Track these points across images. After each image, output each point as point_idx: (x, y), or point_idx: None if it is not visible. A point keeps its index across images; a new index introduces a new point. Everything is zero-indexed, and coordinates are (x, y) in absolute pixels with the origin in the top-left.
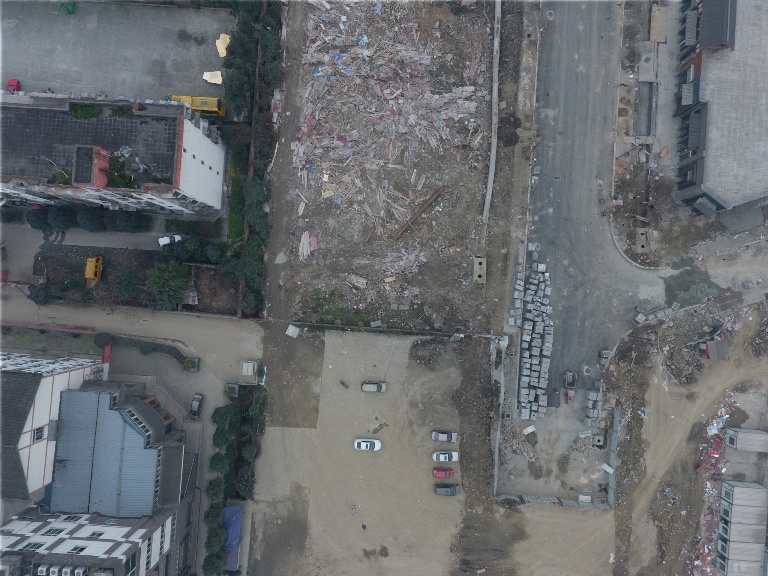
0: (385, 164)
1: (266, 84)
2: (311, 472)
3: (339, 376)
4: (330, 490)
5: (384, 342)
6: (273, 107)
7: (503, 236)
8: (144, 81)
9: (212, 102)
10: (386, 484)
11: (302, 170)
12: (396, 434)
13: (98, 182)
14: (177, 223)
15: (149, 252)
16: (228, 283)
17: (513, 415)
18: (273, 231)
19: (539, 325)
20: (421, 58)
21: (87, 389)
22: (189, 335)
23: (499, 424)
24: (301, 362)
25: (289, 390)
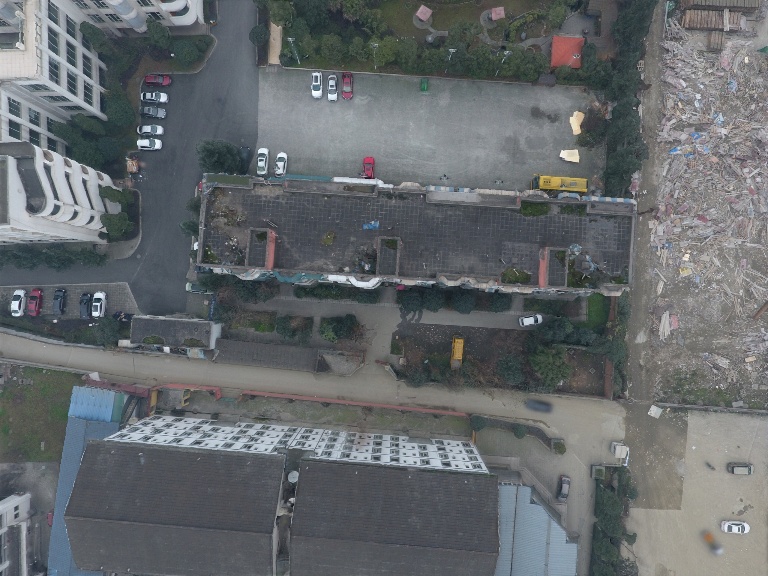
0: (743, 243)
1: None
2: (676, 554)
3: (703, 457)
4: (695, 573)
5: (747, 423)
6: (631, 186)
7: None
8: (498, 158)
9: (582, 183)
10: (752, 567)
11: (661, 249)
12: (761, 516)
13: None
14: (537, 302)
15: (508, 331)
16: (587, 362)
17: None
18: (632, 310)
19: None
20: None
21: None
22: (550, 415)
23: None
24: (664, 443)
25: (652, 471)
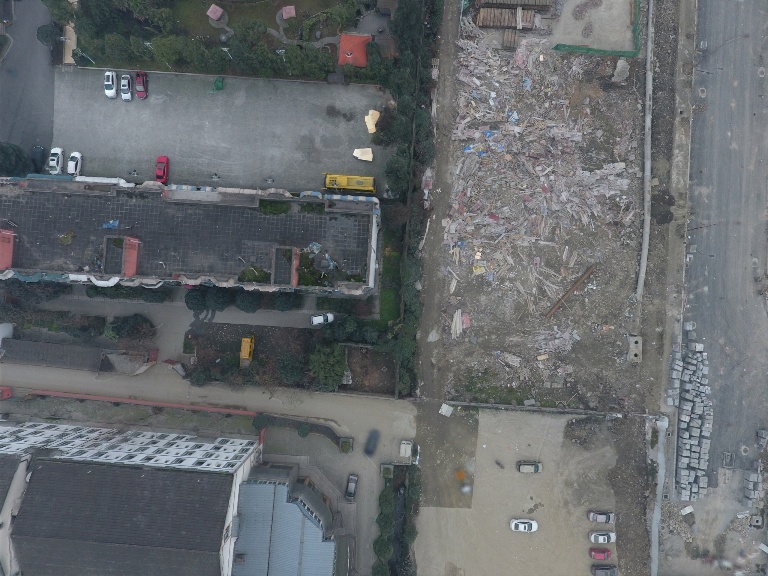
0: (536, 241)
1: (420, 162)
2: (466, 553)
3: (493, 455)
4: (485, 571)
5: (538, 421)
6: (424, 184)
7: (658, 314)
8: (293, 157)
9: (368, 181)
10: (542, 565)
11: (454, 247)
12: (551, 514)
13: (294, 282)
14: (329, 301)
15: (300, 330)
16: (380, 361)
17: (671, 496)
18: (425, 309)
19: (698, 406)
20: (573, 135)
21: (256, 478)
22: (342, 414)
23: (657, 505)
24: (455, 441)
25: (443, 470)
